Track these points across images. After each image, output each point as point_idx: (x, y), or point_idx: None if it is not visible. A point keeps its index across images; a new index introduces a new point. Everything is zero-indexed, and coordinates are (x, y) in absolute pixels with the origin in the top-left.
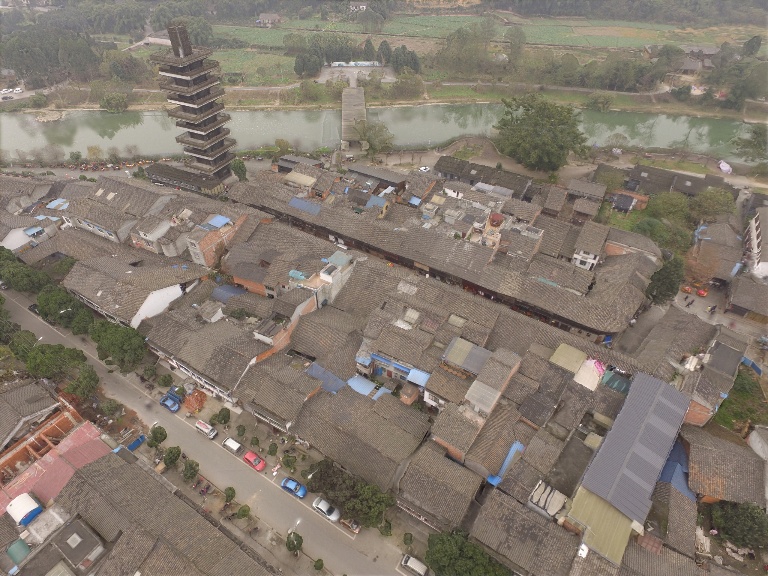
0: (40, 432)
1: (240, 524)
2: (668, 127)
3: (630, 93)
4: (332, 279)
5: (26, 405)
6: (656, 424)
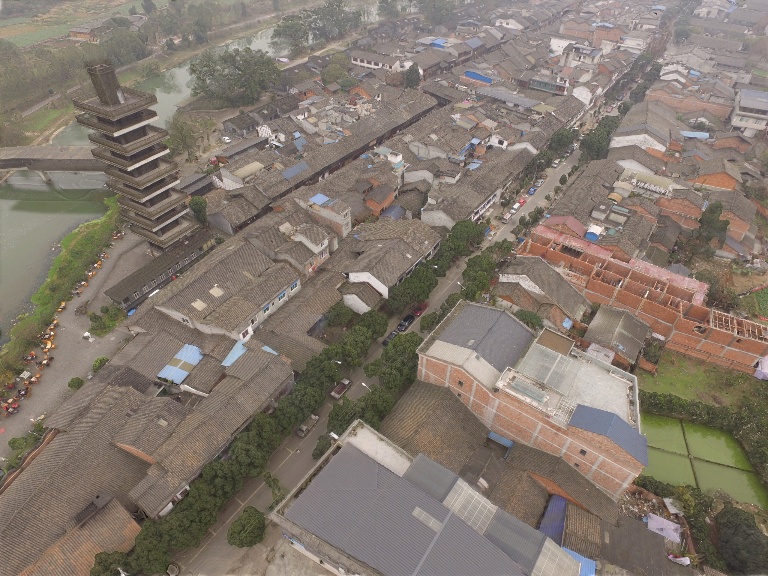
0: None
1: None
2: (180, 74)
3: (148, 58)
4: (401, 156)
5: None
6: (502, 92)
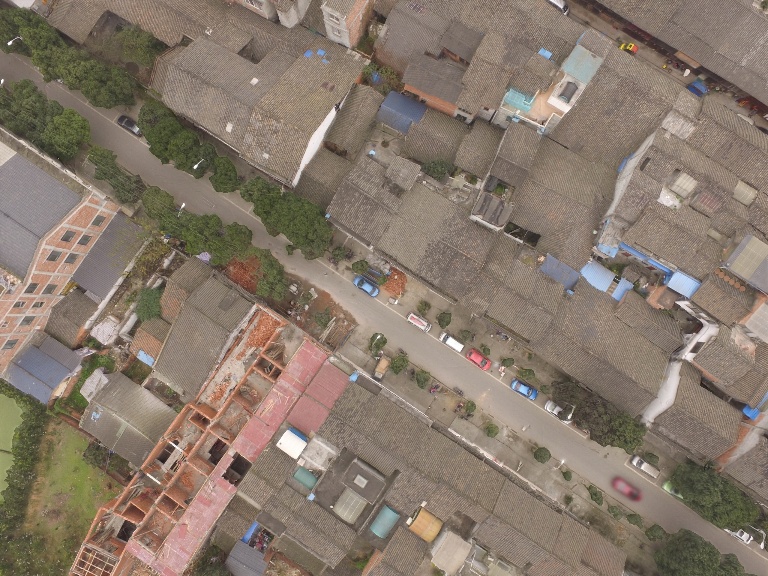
0: (248, 337)
1: (476, 422)
2: None
3: None
4: (569, 109)
5: (223, 314)
6: None
